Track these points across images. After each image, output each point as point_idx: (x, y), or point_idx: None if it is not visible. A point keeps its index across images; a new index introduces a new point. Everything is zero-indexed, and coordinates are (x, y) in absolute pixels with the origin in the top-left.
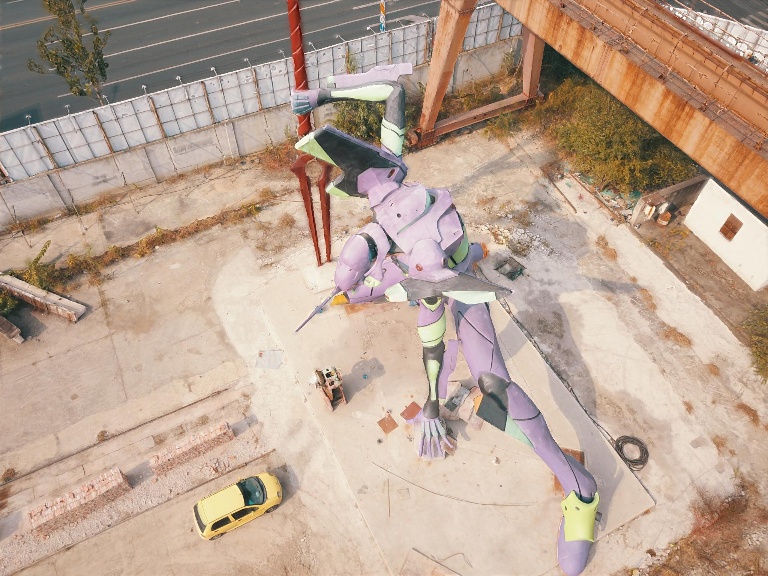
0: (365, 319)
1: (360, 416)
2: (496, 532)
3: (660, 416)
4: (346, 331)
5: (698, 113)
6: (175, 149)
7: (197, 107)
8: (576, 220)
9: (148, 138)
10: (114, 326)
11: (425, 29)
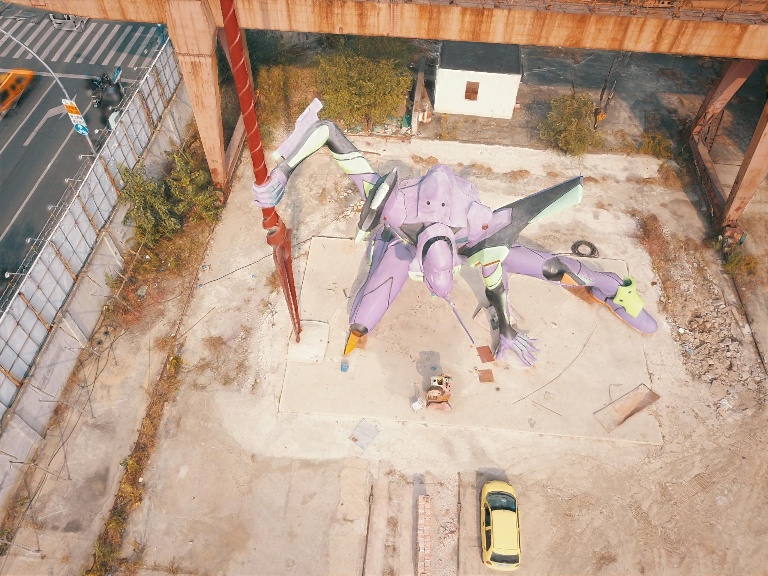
0: (378, 339)
1: (467, 391)
2: (604, 356)
3: (568, 220)
4: (380, 359)
5: (496, 11)
6: (38, 387)
7: (27, 325)
8: (386, 159)
9: (5, 402)
10: (215, 570)
11: (138, 100)
